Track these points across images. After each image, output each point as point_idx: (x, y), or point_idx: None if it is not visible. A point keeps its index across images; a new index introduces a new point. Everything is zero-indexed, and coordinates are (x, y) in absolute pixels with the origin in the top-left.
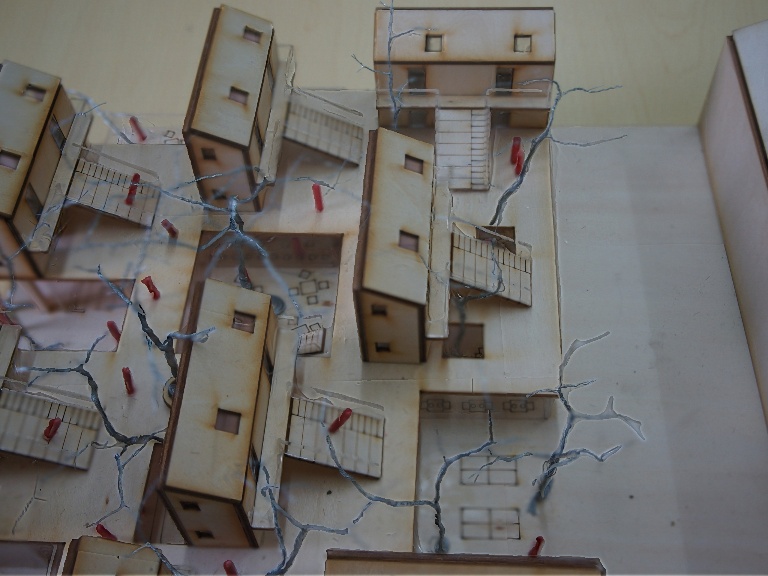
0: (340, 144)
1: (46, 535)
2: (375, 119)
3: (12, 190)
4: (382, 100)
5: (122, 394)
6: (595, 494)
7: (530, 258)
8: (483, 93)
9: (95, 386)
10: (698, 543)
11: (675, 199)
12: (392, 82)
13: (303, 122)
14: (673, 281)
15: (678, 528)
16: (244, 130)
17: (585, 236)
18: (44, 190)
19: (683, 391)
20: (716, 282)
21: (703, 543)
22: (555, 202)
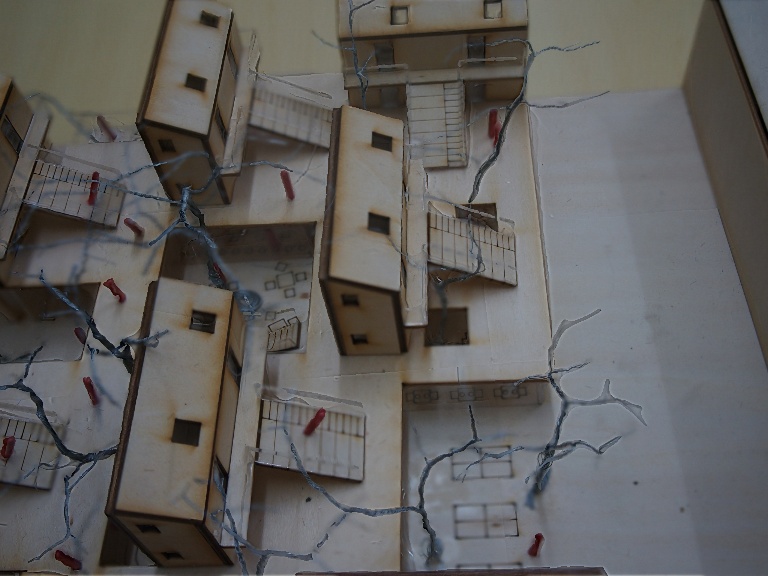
0: (309, 129)
1: (6, 563)
2: (346, 101)
3: None
4: (350, 80)
5: (87, 405)
6: (596, 482)
7: (513, 235)
8: (455, 65)
9: (40, 402)
10: (711, 530)
11: (663, 165)
12: (356, 58)
13: (269, 108)
14: (666, 250)
15: (688, 515)
16: (202, 118)
17: (571, 209)
18: None
19: (684, 366)
20: (712, 248)
21: (716, 530)
22: (538, 175)
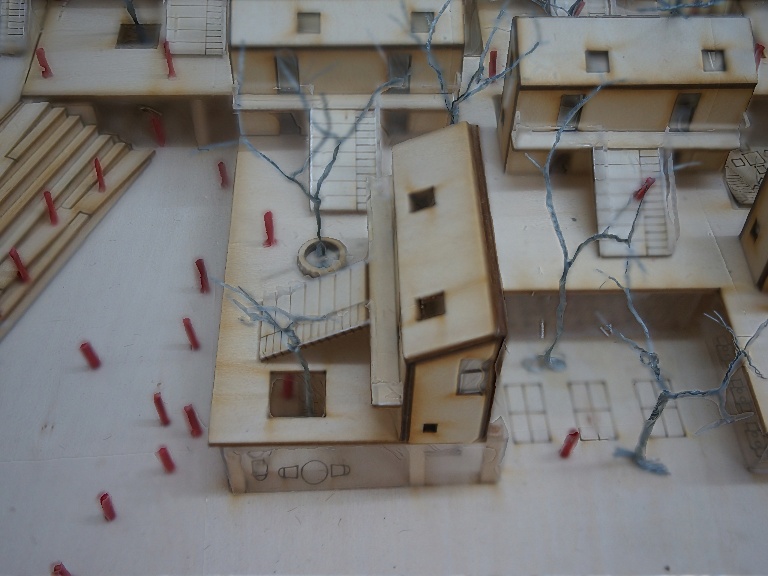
0: None
1: None
2: None
3: None
4: None
5: None
6: (660, 524)
7: None
8: None
9: None
10: None
11: None
12: None
13: None
14: None
15: None
16: None
17: None
18: None
19: None
20: None
21: None
22: None
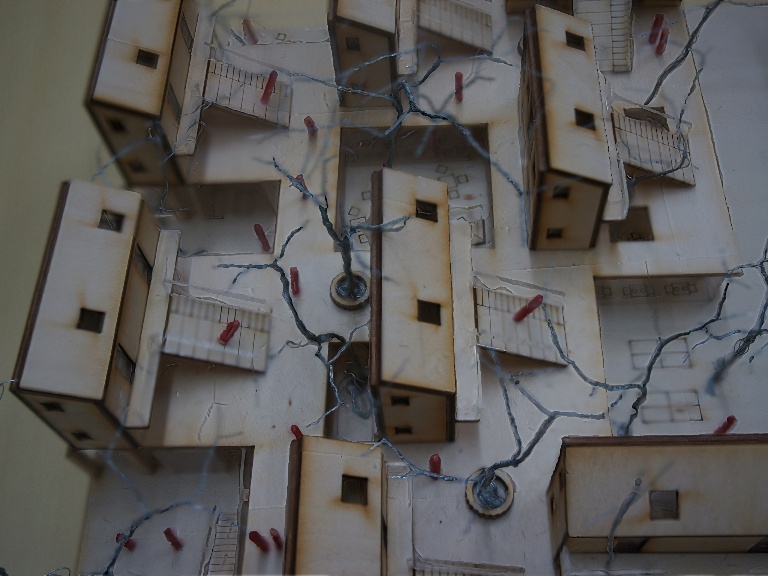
0: (472, 32)
1: (233, 439)
2: (502, 6)
3: (156, 90)
4: None
5: None
6: None
7: (687, 137)
8: None
9: (287, 283)
10: None
11: None
12: None
13: (434, 10)
14: None
15: None
16: (388, 16)
17: (723, 116)
18: (181, 92)
19: None
20: None
21: None
22: None
